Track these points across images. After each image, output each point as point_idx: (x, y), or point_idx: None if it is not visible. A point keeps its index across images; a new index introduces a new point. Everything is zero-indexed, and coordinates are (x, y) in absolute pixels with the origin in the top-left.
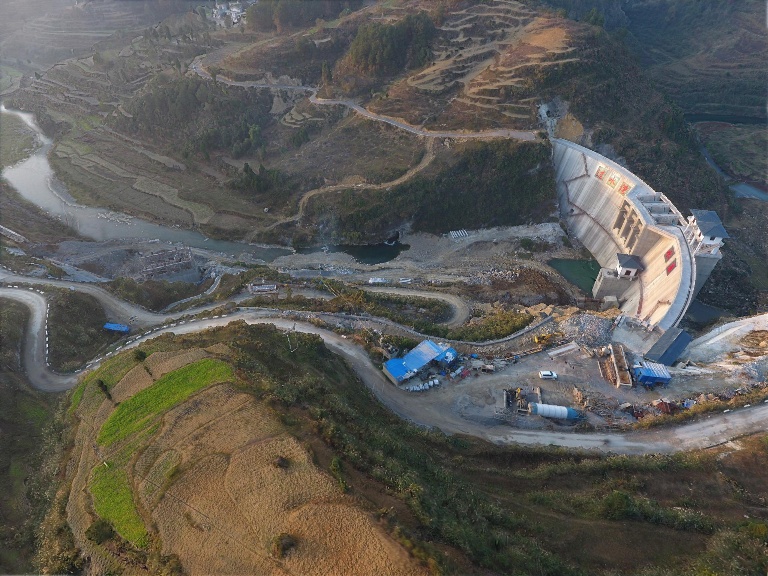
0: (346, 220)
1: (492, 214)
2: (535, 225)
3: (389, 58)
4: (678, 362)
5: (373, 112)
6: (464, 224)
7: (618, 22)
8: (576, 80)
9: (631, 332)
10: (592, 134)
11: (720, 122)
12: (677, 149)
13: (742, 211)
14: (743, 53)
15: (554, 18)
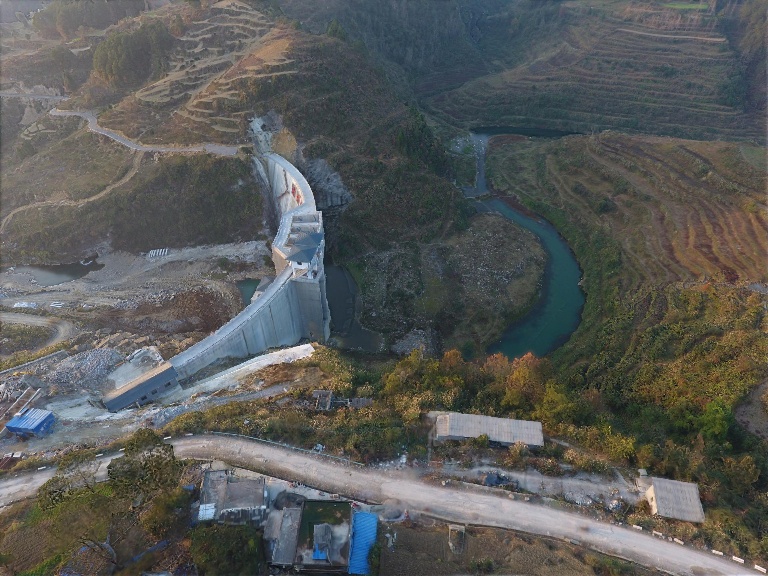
0: (35, 239)
1: (195, 232)
2: (242, 243)
3: (126, 68)
4: (154, 402)
5: (98, 124)
6: (166, 242)
7: (457, 33)
8: (291, 93)
9: (137, 368)
10: (302, 149)
11: (517, 135)
12: (404, 164)
13: (468, 228)
14: (554, 66)
15: (285, 29)
